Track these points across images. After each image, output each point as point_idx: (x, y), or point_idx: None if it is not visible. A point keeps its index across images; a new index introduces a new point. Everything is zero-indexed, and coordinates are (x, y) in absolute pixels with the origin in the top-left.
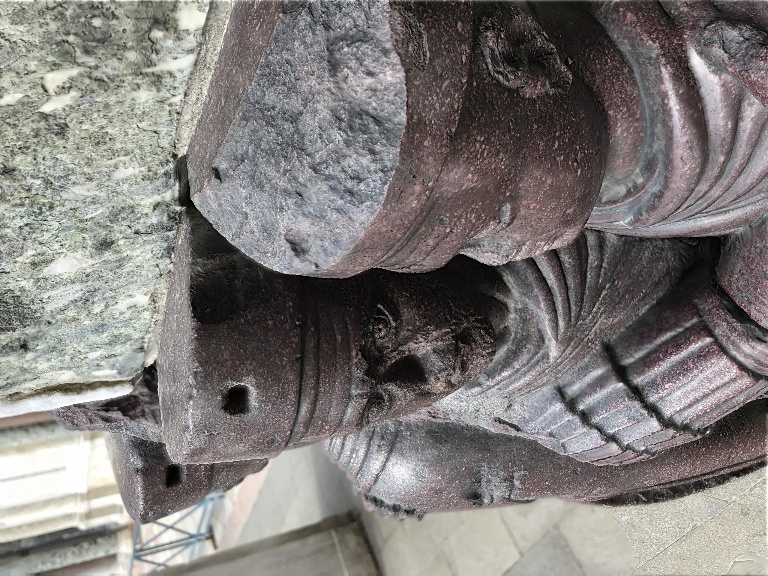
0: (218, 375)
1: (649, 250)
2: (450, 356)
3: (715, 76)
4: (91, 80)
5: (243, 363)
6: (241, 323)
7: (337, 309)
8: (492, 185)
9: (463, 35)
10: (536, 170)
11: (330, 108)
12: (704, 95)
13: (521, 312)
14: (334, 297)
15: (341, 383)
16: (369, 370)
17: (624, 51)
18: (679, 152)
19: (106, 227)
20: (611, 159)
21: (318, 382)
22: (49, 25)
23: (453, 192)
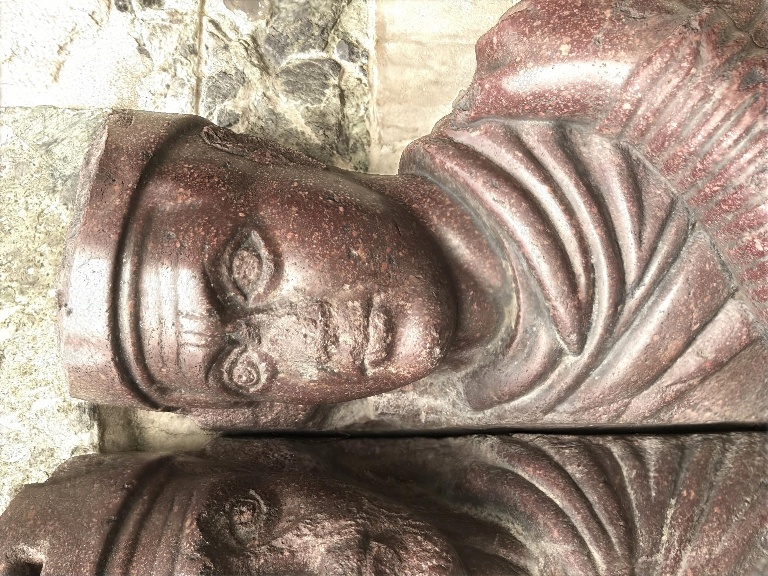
0: (11, 537)
1: (732, 451)
2: (349, 553)
3: (476, 132)
4: (24, 315)
5: (45, 524)
6: (65, 487)
7: (188, 486)
8: (218, 205)
9: (169, 119)
10: (273, 199)
11: (82, 184)
12: (480, 149)
13: (546, 570)
14: (193, 480)
15: (162, 563)
16: (206, 549)
17: (414, 171)
18: (486, 195)
19: (25, 471)
20: (455, 253)
21: (131, 560)
22: (2, 277)
23: (170, 206)
